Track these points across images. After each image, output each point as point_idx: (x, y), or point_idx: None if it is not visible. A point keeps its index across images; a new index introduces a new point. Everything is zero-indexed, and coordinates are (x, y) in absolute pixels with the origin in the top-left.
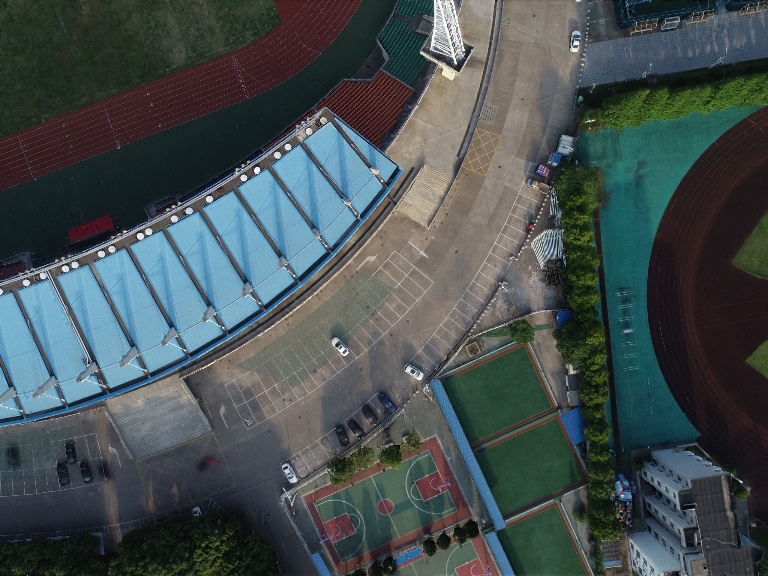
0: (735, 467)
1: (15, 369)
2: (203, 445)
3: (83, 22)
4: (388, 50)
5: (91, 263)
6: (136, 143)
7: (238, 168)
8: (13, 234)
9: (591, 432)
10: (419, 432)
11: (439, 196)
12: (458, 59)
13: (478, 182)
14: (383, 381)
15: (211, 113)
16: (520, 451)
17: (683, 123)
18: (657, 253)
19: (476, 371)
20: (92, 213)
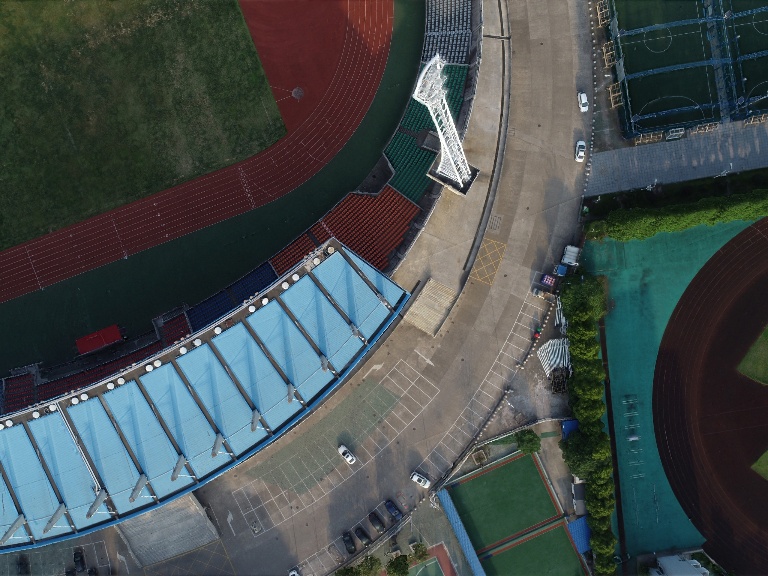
0: (741, 573)
1: (25, 497)
2: (211, 552)
3: (90, 133)
4: (394, 164)
5: (100, 395)
6: (143, 253)
7: (246, 300)
8: (21, 343)
9: (597, 544)
10: (426, 539)
11: (445, 307)
12: (464, 181)
13: (484, 291)
14: (390, 488)
15: (218, 223)
16: (526, 558)
17: (688, 231)
18: (662, 360)
19: (482, 478)
20: (100, 322)
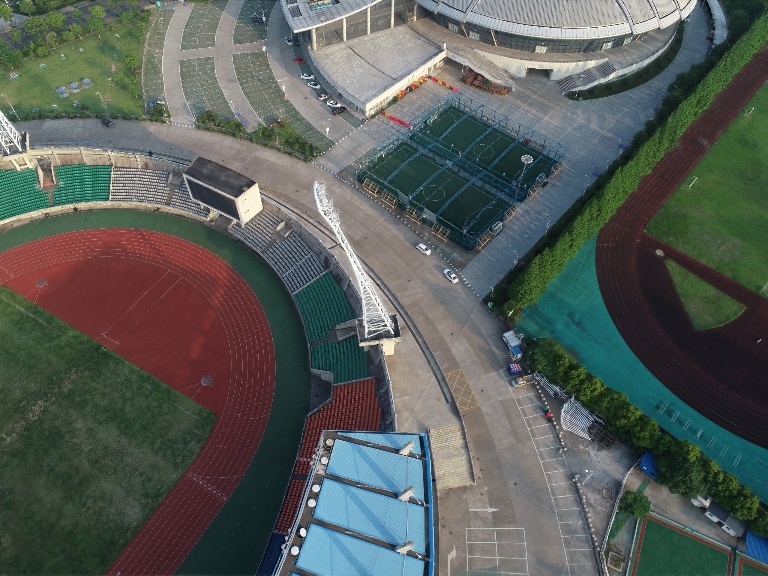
0: None
1: None
2: None
3: (8, 555)
4: (326, 369)
5: None
6: None
7: (283, 545)
8: None
9: None
10: None
11: (461, 447)
12: (392, 330)
13: (477, 414)
14: None
15: (198, 541)
16: None
17: (566, 274)
18: (647, 362)
19: None
20: None
